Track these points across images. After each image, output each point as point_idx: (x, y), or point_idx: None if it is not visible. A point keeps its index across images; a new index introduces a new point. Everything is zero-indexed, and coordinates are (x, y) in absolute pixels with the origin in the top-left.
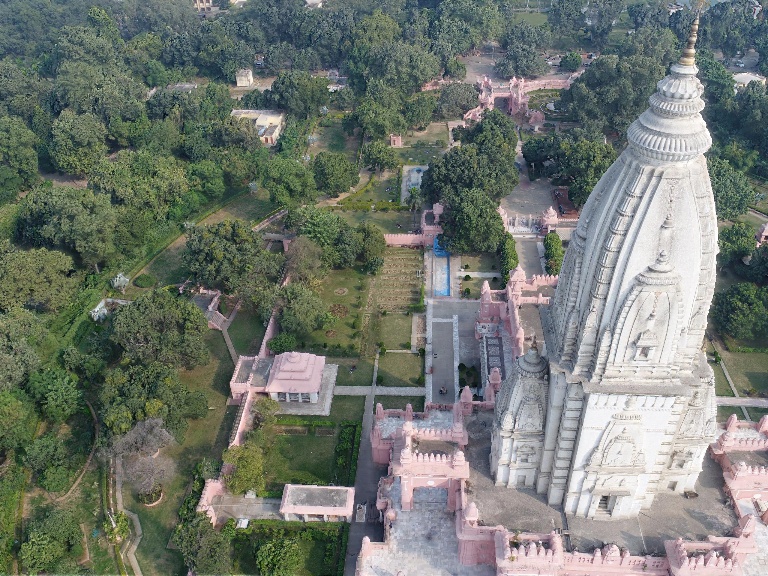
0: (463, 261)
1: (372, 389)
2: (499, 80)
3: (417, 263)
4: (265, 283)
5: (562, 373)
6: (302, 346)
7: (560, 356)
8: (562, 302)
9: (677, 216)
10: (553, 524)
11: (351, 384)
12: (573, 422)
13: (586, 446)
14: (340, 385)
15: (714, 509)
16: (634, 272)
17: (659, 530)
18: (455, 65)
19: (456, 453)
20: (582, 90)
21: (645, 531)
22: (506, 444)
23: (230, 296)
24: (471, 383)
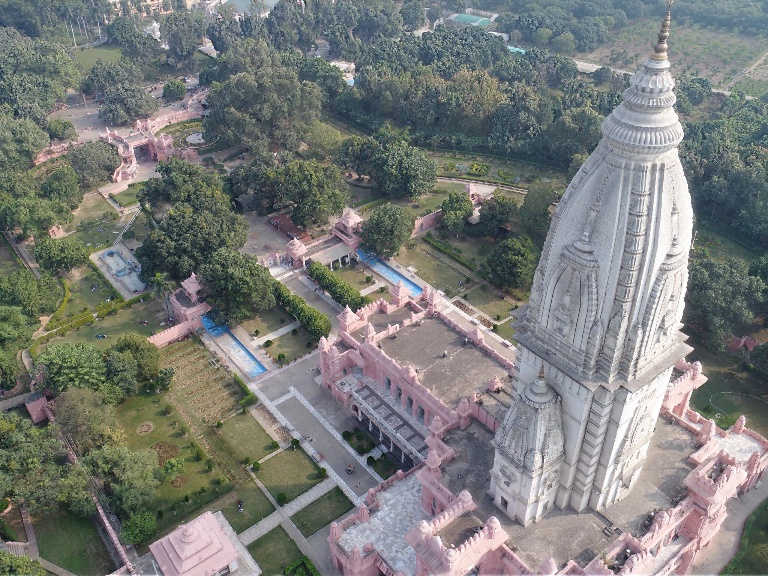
0: (247, 329)
1: (280, 513)
2: (112, 128)
3: (201, 354)
4: (56, 470)
5: (599, 387)
6: (159, 516)
7: (585, 372)
8: (572, 321)
9: (679, 199)
10: (597, 528)
11: (253, 523)
12: (604, 426)
13: (619, 441)
14: (242, 531)
15: (670, 433)
16: (658, 264)
17: (660, 476)
18: (59, 126)
19: (493, 522)
20: (236, 115)
21: (653, 484)
22: (534, 483)
23: (4, 513)
24: (368, 446)
